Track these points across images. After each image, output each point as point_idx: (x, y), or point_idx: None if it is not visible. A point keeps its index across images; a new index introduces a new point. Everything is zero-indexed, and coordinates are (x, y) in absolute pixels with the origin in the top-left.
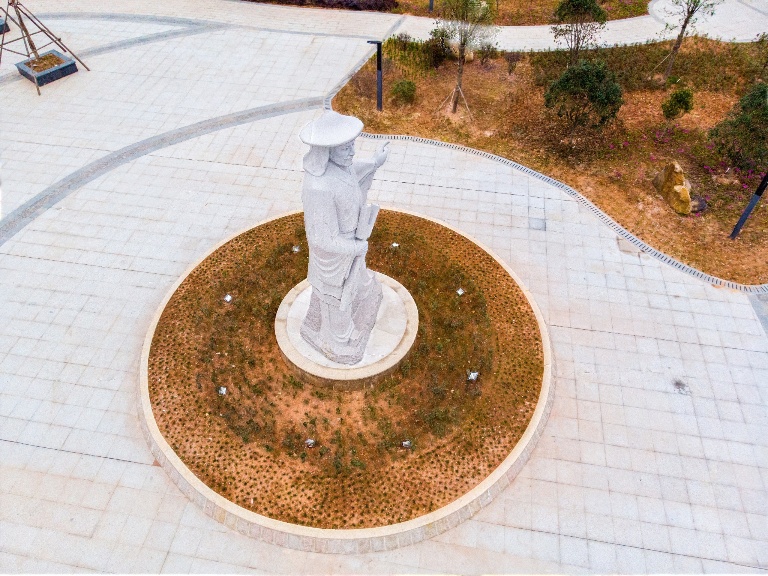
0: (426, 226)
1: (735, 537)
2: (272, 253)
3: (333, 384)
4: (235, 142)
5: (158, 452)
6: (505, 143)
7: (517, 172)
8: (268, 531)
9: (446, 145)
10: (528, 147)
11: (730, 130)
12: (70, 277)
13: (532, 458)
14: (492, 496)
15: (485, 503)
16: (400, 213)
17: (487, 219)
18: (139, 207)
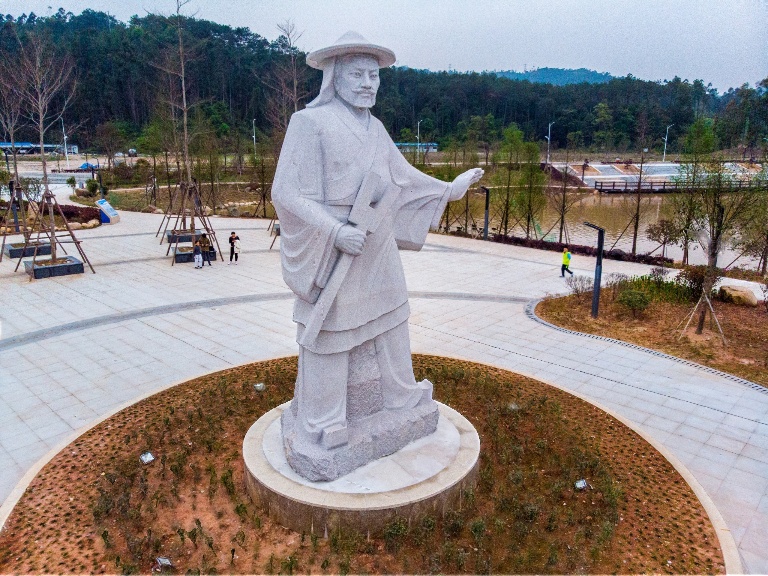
0: (577, 405)
1: None
2: None
3: (269, 501)
4: None
5: None
6: None
7: None
8: None
9: (669, 357)
10: None
11: None
12: (162, 345)
13: None
14: None
15: None
16: (547, 385)
17: (695, 435)
18: (274, 322)
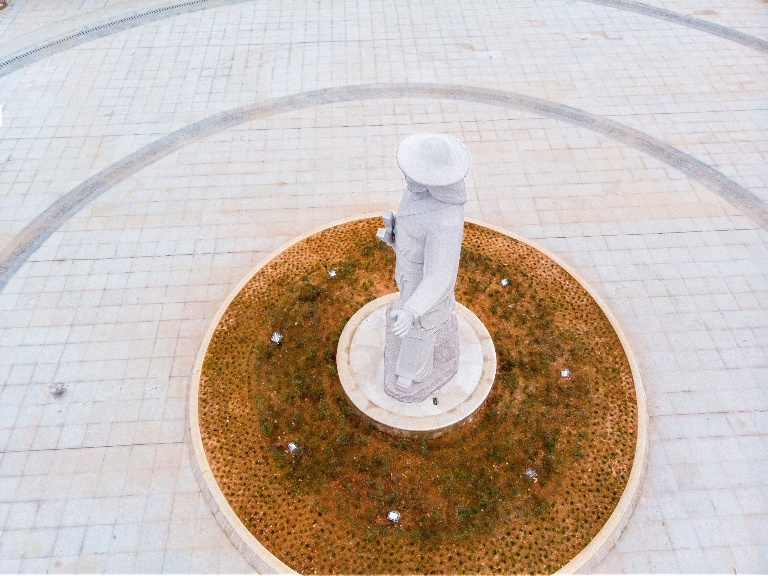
0: None
1: (82, 274)
2: None
3: None
4: None
5: None
6: None
7: None
8: None
9: None
10: None
11: None
12: None
13: None
14: None
15: None
16: None
17: None
18: None
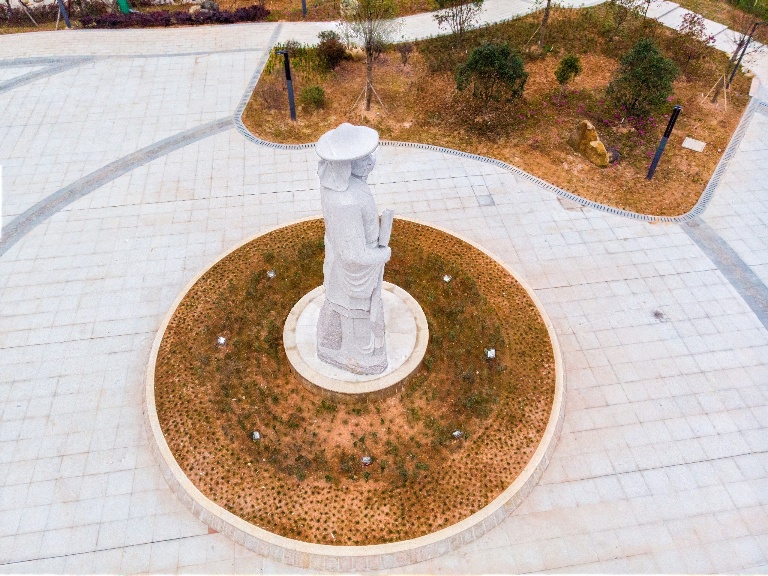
0: None
1: (750, 431)
2: (250, 284)
3: (367, 397)
4: (156, 179)
5: (211, 518)
6: (426, 131)
7: (448, 156)
8: (360, 559)
9: None
10: (448, 131)
11: (626, 84)
12: (25, 363)
13: (567, 414)
14: (548, 458)
15: (545, 467)
16: None
17: (439, 205)
18: (76, 269)
